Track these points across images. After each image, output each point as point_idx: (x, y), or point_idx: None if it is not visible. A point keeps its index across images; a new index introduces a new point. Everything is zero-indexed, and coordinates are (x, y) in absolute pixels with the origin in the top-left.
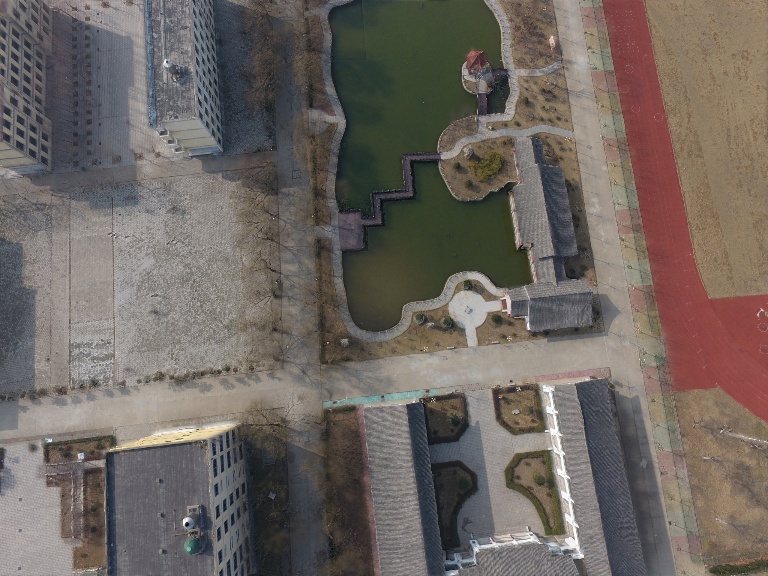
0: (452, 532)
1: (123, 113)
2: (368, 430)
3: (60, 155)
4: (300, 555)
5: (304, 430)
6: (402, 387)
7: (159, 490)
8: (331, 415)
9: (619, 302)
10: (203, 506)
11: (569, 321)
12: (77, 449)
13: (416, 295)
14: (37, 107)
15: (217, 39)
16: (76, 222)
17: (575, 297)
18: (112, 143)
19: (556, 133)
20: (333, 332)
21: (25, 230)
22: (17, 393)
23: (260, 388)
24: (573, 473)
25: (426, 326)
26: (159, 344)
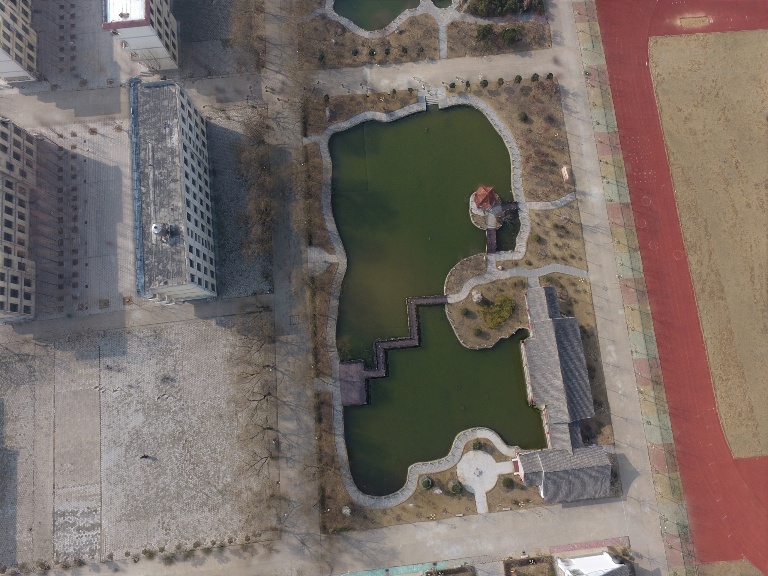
0: None
1: (111, 252)
2: None
3: (44, 300)
4: None
5: None
6: (408, 559)
7: None
8: None
9: (638, 463)
10: None
11: (586, 492)
12: None
13: (422, 455)
14: (19, 250)
15: (211, 169)
16: (61, 374)
17: (592, 469)
18: (99, 286)
19: (570, 273)
20: (334, 498)
21: (7, 384)
22: None
23: (256, 561)
24: None
25: (433, 491)
26: (149, 512)
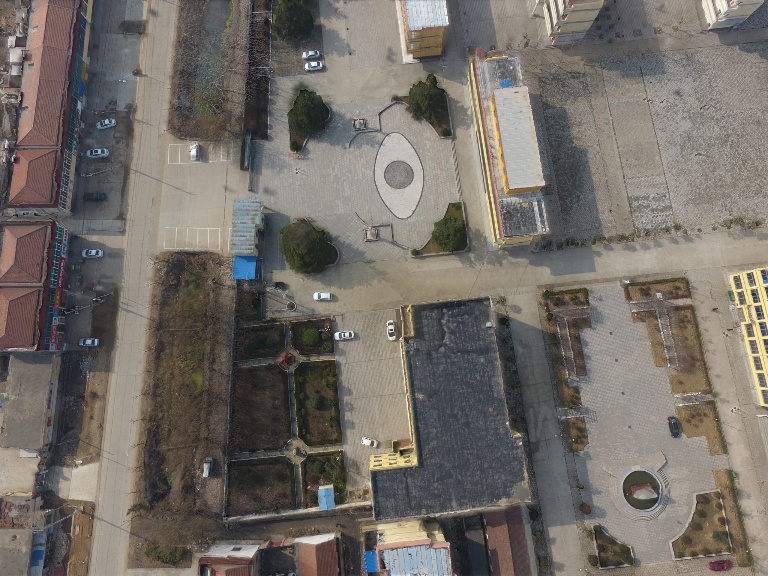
0: None
1: None
2: None
3: None
4: None
5: None
6: None
7: None
8: None
9: None
10: None
11: None
12: (655, 289)
13: None
14: None
15: None
16: (611, 89)
17: None
18: (630, 18)
19: None
20: None
21: (565, 96)
22: (588, 240)
23: None
24: None
25: None
26: (711, 197)
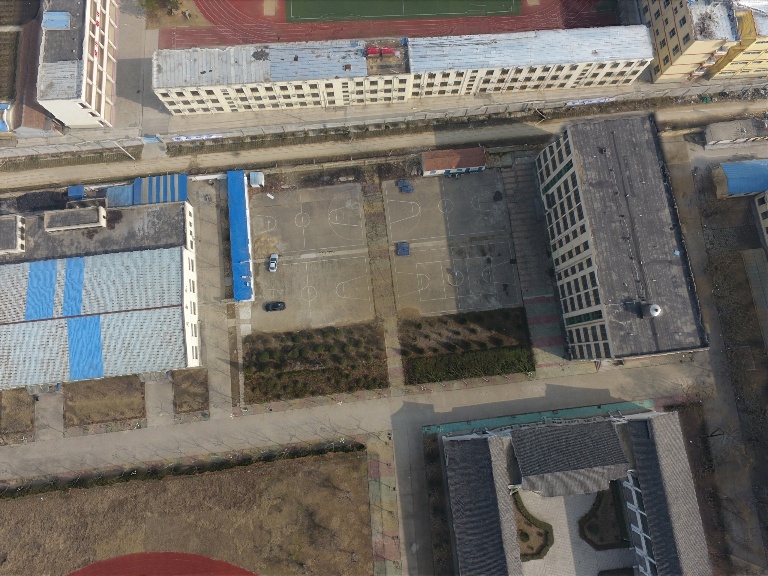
0: None
1: None
2: None
3: None
4: None
5: None
6: None
7: None
8: None
9: None
10: None
11: None
12: None
13: None
14: None
15: None
16: None
17: None
18: None
19: None
20: None
21: None
22: None
23: None
24: (520, 571)
25: None
26: None
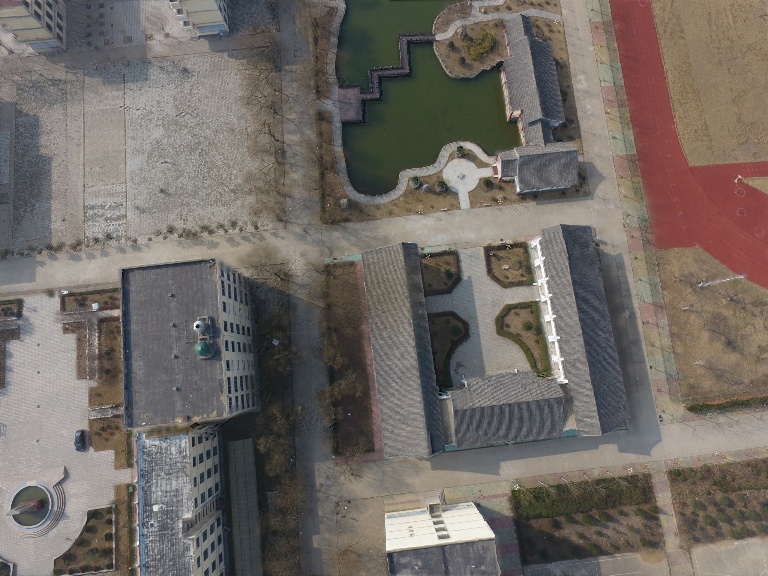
0: (445, 374)
1: None
2: (366, 271)
3: (74, 35)
4: (302, 395)
5: (306, 283)
6: None
7: (171, 304)
8: (331, 270)
9: (604, 169)
10: (212, 318)
11: (556, 180)
12: (92, 300)
13: (412, 163)
14: None
15: None
16: (90, 96)
17: (562, 155)
18: (123, 25)
19: (545, 16)
20: (333, 196)
21: (41, 103)
22: (35, 250)
23: (264, 246)
24: (558, 306)
25: (421, 190)
26: (169, 206)
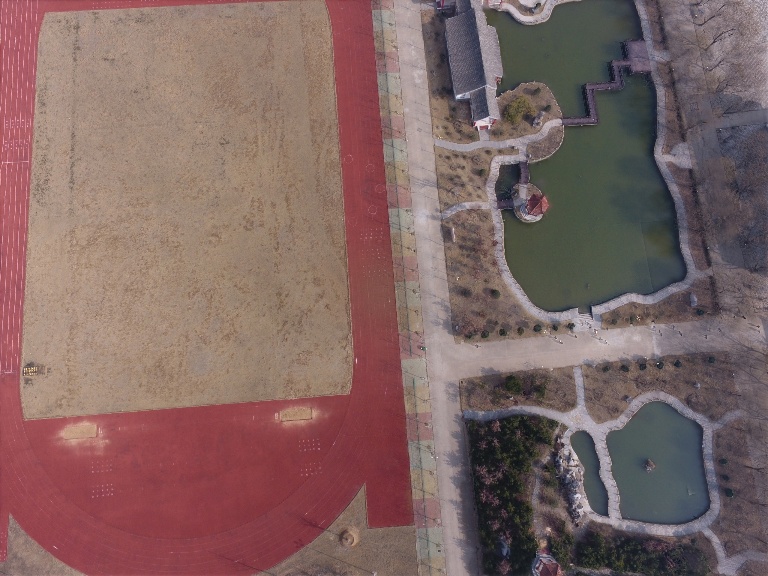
0: None
1: None
2: None
3: None
4: None
5: None
6: None
7: None
8: None
9: None
10: None
11: None
12: None
13: (576, 6)
14: None
15: None
16: None
17: None
18: None
19: (451, 144)
20: None
21: None
22: None
23: None
24: None
25: None
26: None
